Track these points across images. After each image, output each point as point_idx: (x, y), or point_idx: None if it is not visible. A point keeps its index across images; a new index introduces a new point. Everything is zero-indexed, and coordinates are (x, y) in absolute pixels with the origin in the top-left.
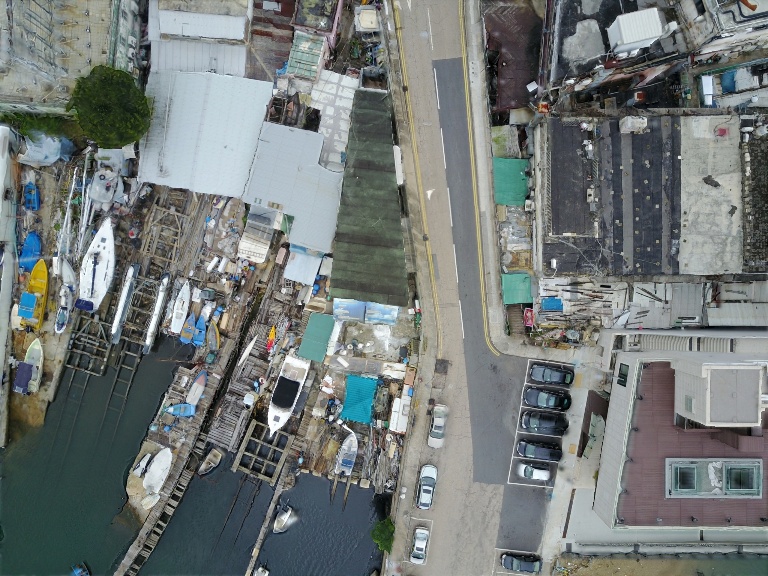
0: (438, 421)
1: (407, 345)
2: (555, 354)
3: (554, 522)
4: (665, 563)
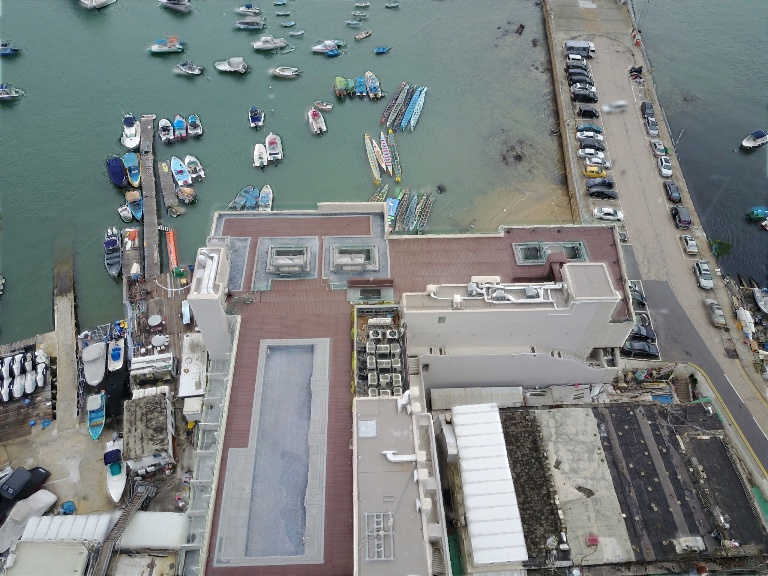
0: (720, 313)
1: (762, 374)
2: (641, 365)
3: None
4: None
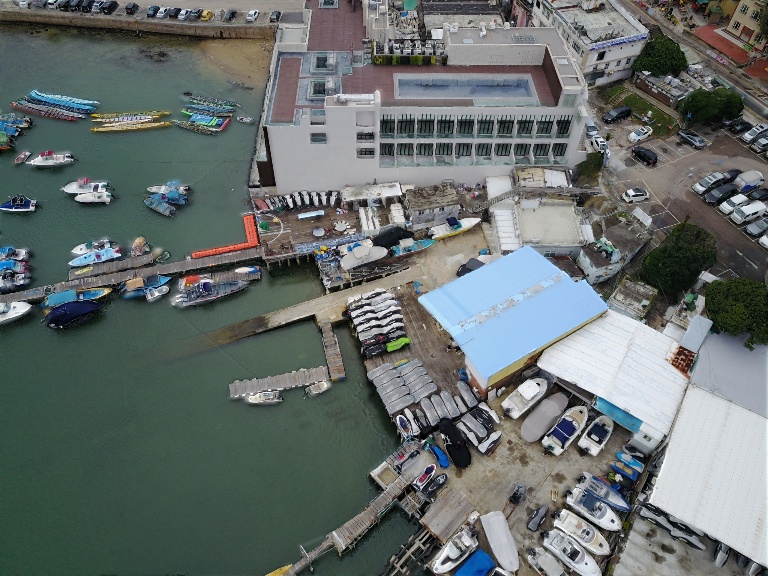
0: None
1: None
2: None
3: (294, 25)
4: (260, 77)
